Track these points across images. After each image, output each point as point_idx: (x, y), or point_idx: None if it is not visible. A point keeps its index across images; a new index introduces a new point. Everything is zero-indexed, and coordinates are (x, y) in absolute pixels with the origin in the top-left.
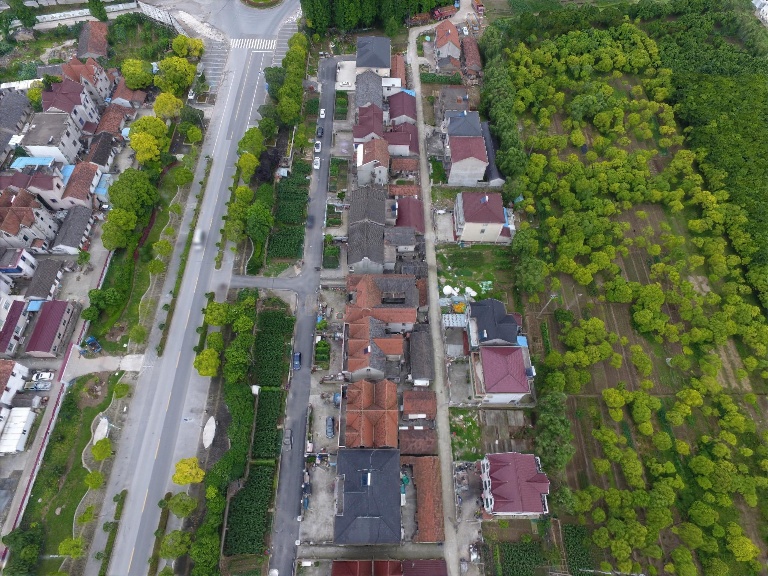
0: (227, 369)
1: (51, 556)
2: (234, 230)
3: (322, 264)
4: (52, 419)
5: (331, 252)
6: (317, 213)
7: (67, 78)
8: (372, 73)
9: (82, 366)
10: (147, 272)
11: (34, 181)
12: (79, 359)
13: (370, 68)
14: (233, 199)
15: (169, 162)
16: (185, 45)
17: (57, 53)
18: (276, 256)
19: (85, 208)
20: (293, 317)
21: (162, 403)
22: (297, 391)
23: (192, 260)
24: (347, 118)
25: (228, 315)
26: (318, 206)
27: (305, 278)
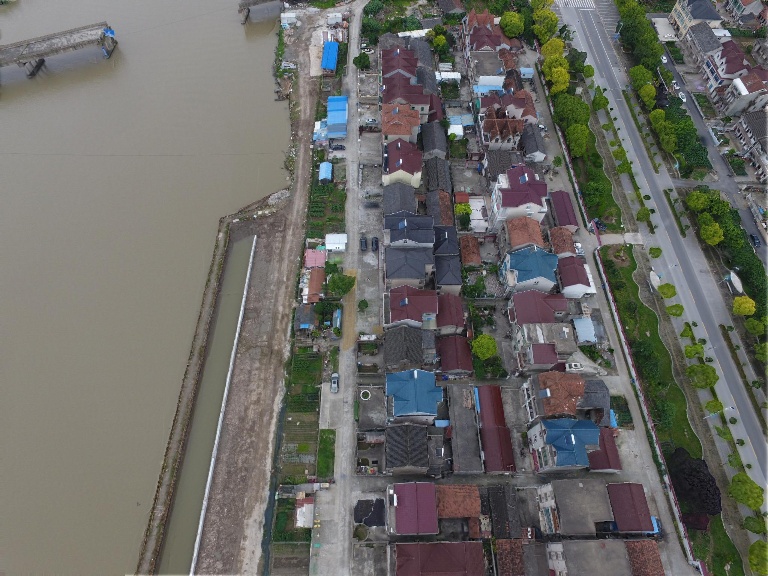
0: (731, 238)
1: (711, 347)
2: (673, 141)
3: (734, 172)
4: (605, 273)
5: (738, 163)
6: (704, 135)
7: (482, 24)
8: (706, 24)
9: (596, 240)
10: (604, 175)
11: (512, 100)
12: (590, 235)
13: (706, 20)
14: (638, 122)
15: (572, 94)
16: (543, 1)
17: (417, 10)
18: (695, 165)
19: (535, 126)
20: (737, 209)
21: (675, 266)
22: (766, 262)
23: (633, 167)
24: (685, 63)
25: (709, 201)
26: (702, 130)
27: (724, 182)
